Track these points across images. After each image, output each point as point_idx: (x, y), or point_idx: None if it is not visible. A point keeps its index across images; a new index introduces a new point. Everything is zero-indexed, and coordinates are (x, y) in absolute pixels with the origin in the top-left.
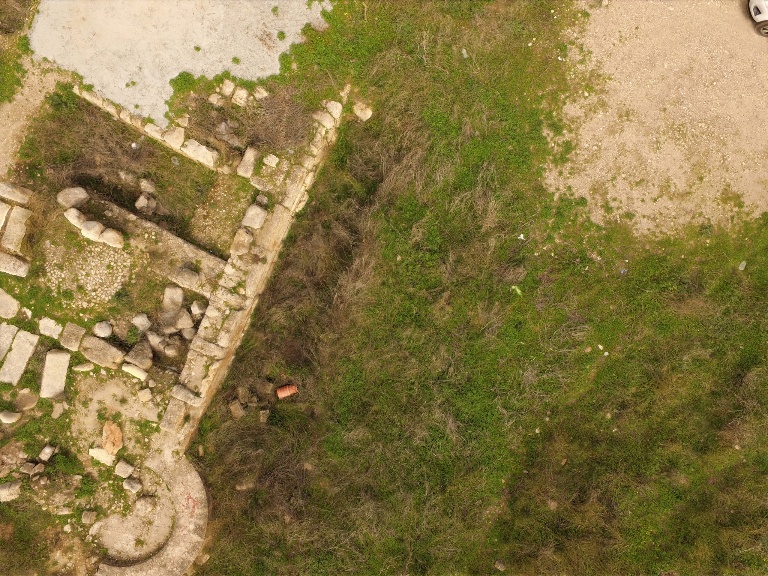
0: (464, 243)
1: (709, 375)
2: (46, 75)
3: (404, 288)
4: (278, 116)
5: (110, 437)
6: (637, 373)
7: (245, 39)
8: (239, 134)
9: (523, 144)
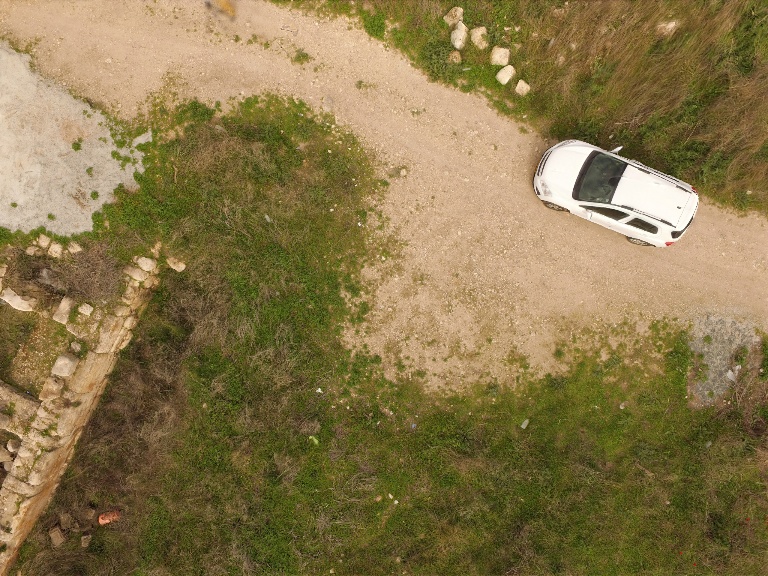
0: None
1: (491, 525)
2: None
3: (209, 434)
4: (92, 269)
5: None
6: (425, 521)
7: (60, 197)
8: (61, 279)
9: (322, 304)
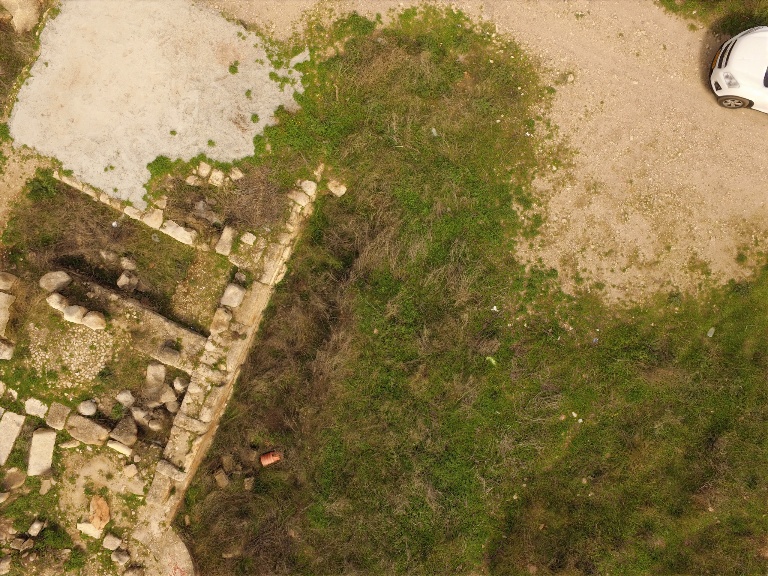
0: (438, 316)
1: (681, 440)
2: (26, 162)
3: (381, 360)
4: (254, 196)
5: (97, 512)
6: (611, 439)
7: (220, 122)
8: (217, 211)
9: (494, 218)
